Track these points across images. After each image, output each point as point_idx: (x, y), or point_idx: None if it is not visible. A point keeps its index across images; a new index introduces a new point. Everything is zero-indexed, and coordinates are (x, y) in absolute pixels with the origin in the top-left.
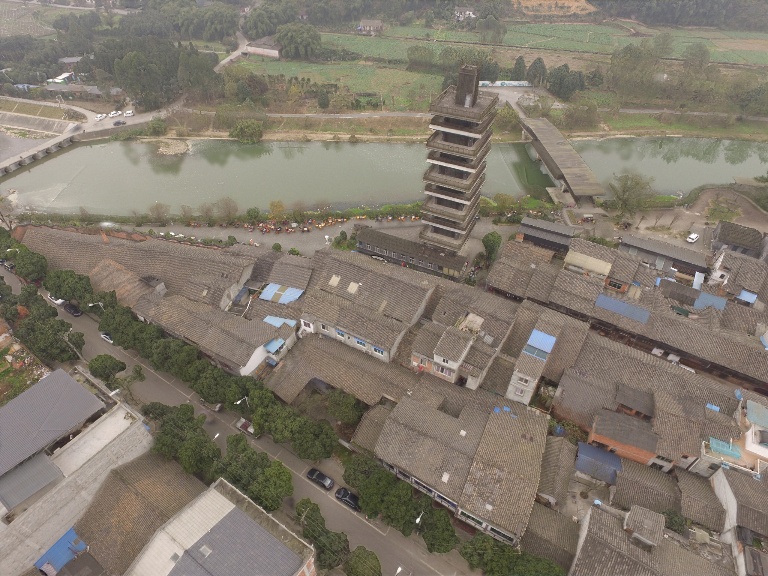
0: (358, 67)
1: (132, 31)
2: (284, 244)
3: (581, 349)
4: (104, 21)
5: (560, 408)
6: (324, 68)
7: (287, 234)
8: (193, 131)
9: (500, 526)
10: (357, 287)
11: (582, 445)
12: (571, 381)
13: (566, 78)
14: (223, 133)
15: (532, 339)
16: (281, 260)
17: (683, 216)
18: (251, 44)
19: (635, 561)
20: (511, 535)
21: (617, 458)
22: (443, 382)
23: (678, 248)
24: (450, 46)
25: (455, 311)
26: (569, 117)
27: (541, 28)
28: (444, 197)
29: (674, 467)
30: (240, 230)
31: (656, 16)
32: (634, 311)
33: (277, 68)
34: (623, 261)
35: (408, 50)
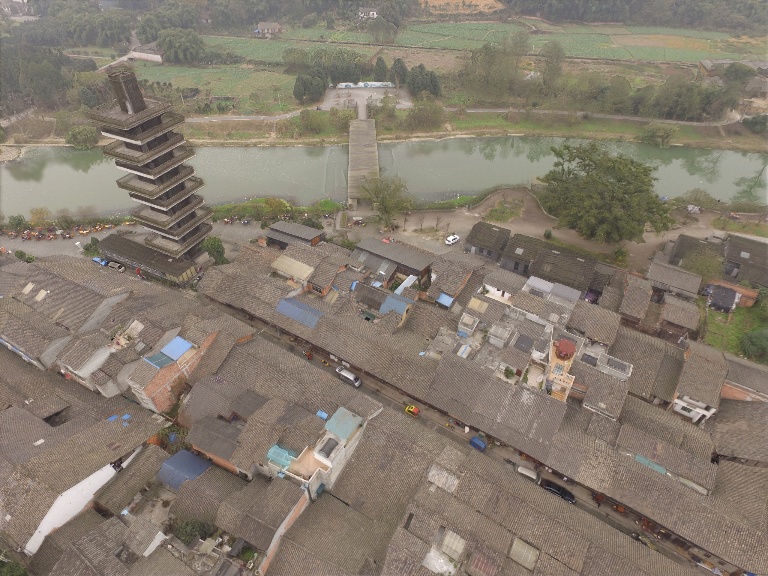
0: (235, 70)
1: (23, 38)
2: (37, 251)
3: (230, 355)
4: (1, 29)
5: (182, 416)
6: (201, 72)
7: (47, 241)
8: (33, 138)
9: (10, 537)
10: (44, 295)
11: (180, 453)
12: (201, 388)
13: (417, 78)
14: (62, 139)
15: (168, 346)
16: (1, 268)
17: (460, 217)
18: (136, 49)
19: (95, 573)
20: (13, 546)
21: (206, 466)
22: (80, 390)
23: (415, 251)
24: (338, 47)
25: (123, 318)
26: (412, 118)
27: (443, 27)
28: (146, 203)
29: (255, 475)
30: (3, 237)
31: (561, 13)
32: (306, 316)
33: (154, 73)
34: (326, 265)
35: (284, 52)
